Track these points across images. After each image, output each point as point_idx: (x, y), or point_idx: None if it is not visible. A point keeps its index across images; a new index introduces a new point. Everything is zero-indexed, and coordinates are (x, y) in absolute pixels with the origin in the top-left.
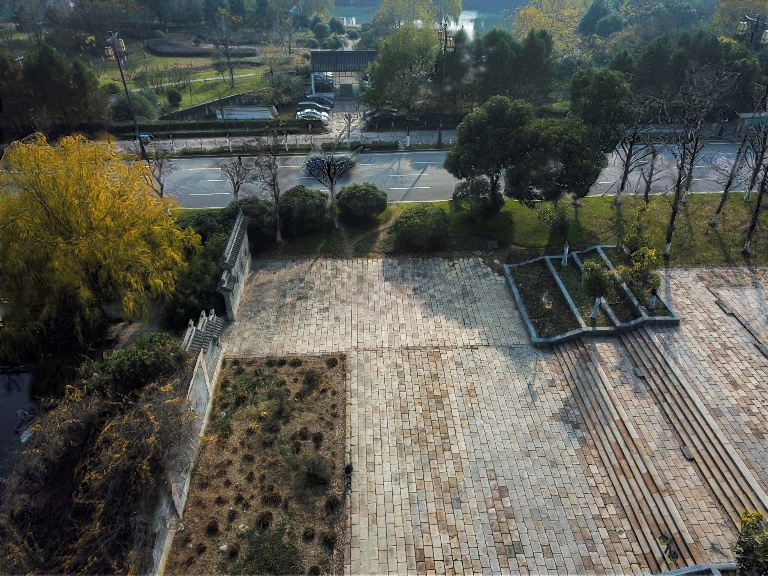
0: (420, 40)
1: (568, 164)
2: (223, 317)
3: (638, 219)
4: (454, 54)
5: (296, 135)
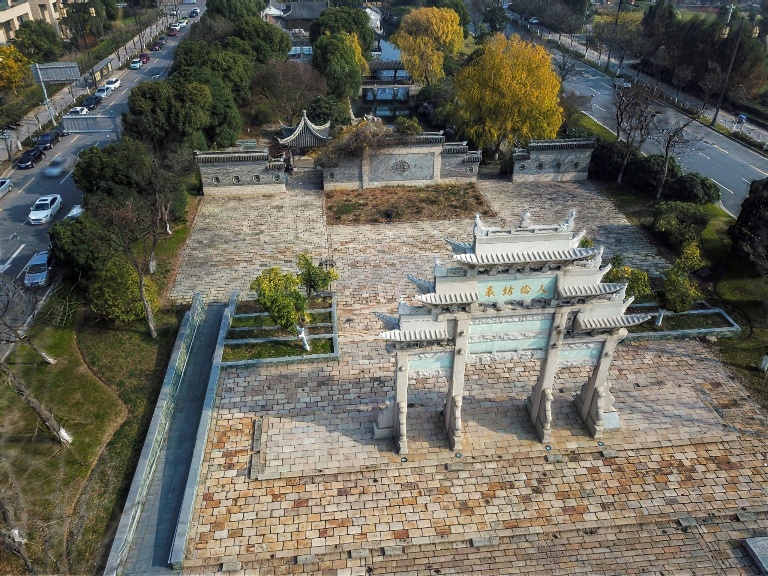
0: None
1: None
2: None
3: None
4: None
5: None
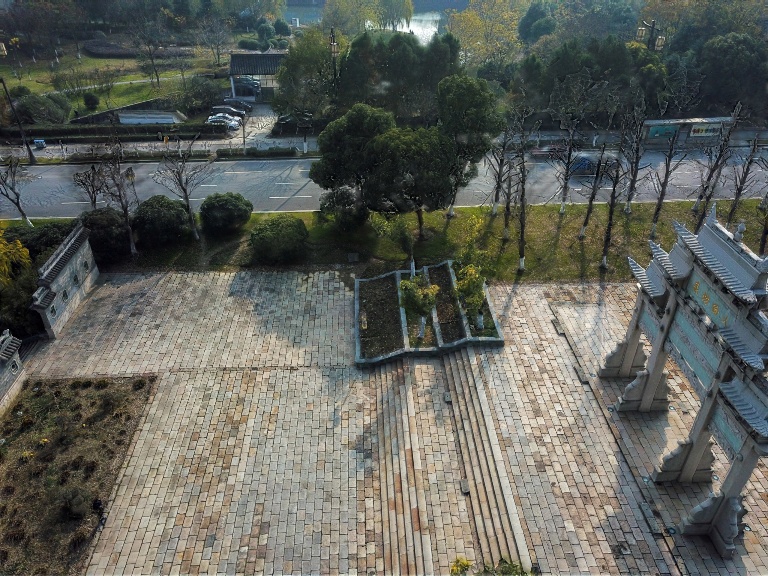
0: (326, 44)
1: (417, 176)
2: (43, 335)
3: (470, 235)
4: (356, 58)
5: (196, 140)
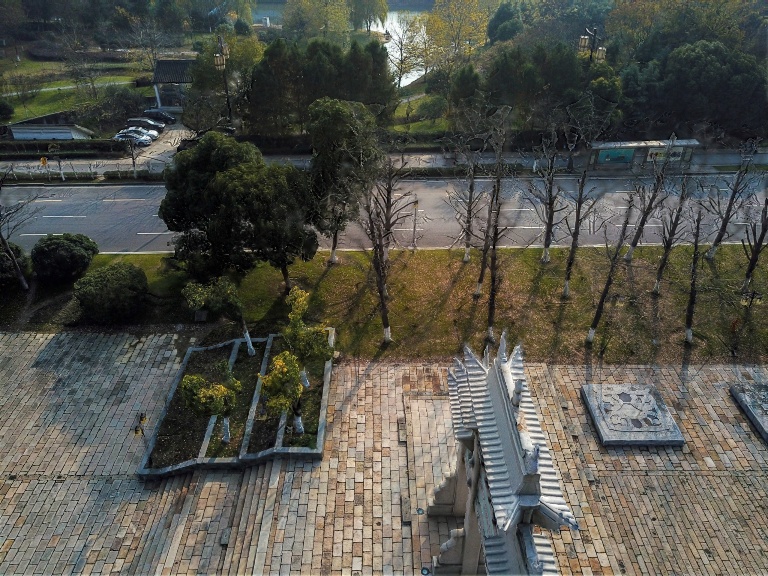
0: (240, 51)
1: (256, 225)
2: None
3: None
4: (265, 69)
5: (90, 160)
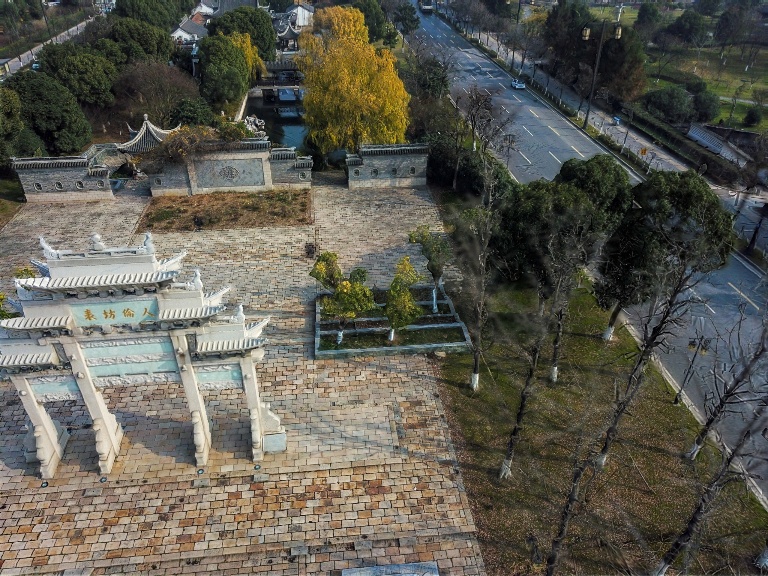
0: None
1: None
2: None
3: None
4: None
5: None
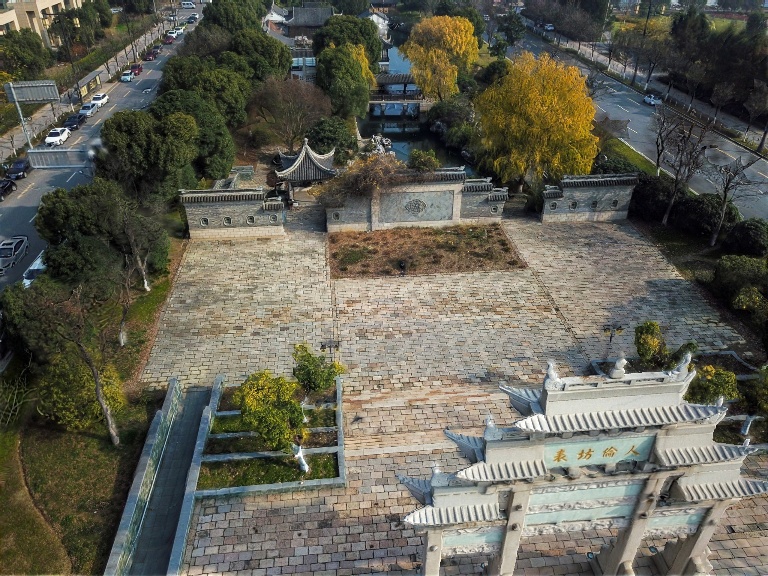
0: None
1: None
2: (540, 216)
3: None
4: None
5: None
